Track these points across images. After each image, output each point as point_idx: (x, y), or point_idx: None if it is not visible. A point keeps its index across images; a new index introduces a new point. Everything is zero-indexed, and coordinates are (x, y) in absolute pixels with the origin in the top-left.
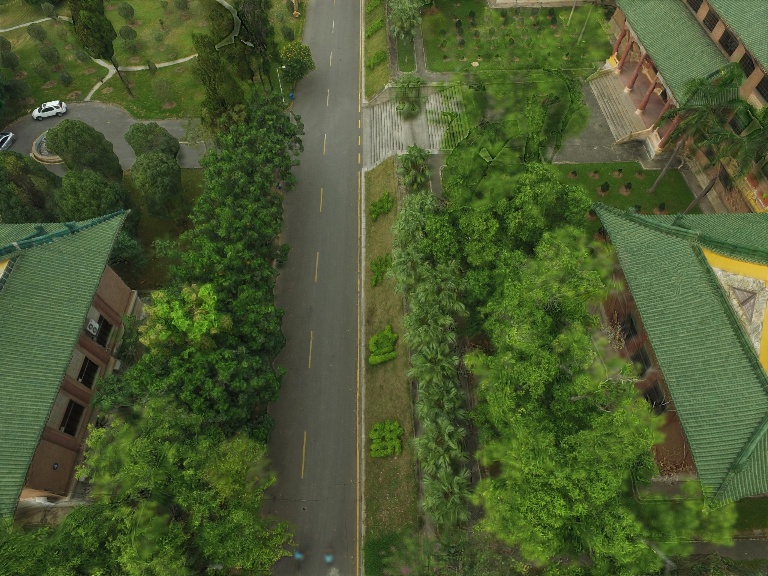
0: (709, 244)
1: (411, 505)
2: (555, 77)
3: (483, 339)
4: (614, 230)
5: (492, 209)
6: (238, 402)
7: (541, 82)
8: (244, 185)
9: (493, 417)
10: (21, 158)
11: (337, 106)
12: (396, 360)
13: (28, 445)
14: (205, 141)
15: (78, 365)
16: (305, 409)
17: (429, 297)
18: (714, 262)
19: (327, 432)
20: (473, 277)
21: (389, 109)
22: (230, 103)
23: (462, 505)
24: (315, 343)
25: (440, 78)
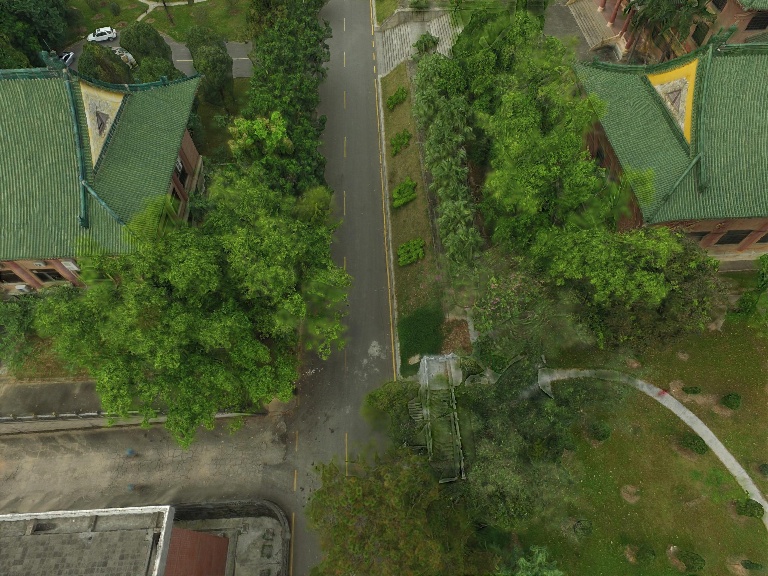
0: (652, 71)
1: (433, 286)
2: (540, 3)
3: (486, 164)
4: (584, 77)
5: (492, 48)
6: (303, 200)
7: (528, 7)
8: (291, 62)
9: (496, 195)
10: (104, 48)
11: (353, 31)
12: (416, 199)
13: (155, 213)
14: (253, 38)
15: (170, 190)
16: (343, 242)
17: (445, 122)
18: (655, 82)
19: (362, 257)
20: (479, 103)
21: (398, 31)
22: (274, 4)
23: (475, 246)
24: (348, 199)
25: (442, 4)
